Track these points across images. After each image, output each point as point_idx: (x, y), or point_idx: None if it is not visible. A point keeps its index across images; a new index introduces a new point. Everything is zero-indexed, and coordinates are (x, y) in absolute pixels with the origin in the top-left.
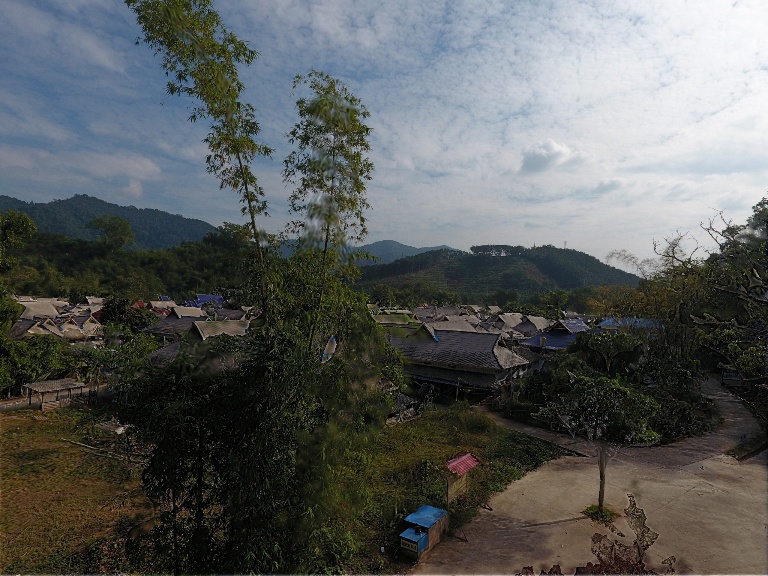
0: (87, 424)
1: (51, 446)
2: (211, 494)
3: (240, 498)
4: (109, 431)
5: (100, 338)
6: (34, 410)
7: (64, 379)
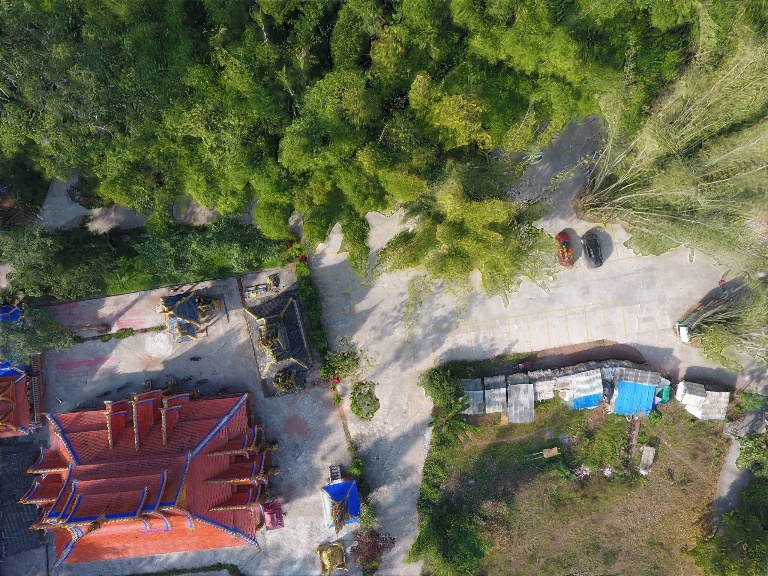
0: None
1: (616, 567)
2: None
3: None
4: None
5: None
6: None
7: None
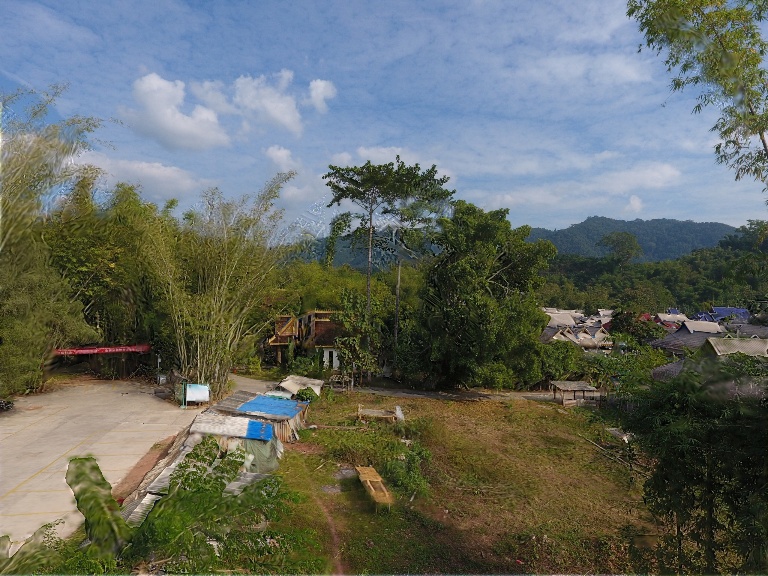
0: (598, 426)
1: (570, 438)
2: (725, 536)
3: (761, 554)
4: (617, 437)
5: (610, 348)
6: (558, 404)
7: (580, 381)
